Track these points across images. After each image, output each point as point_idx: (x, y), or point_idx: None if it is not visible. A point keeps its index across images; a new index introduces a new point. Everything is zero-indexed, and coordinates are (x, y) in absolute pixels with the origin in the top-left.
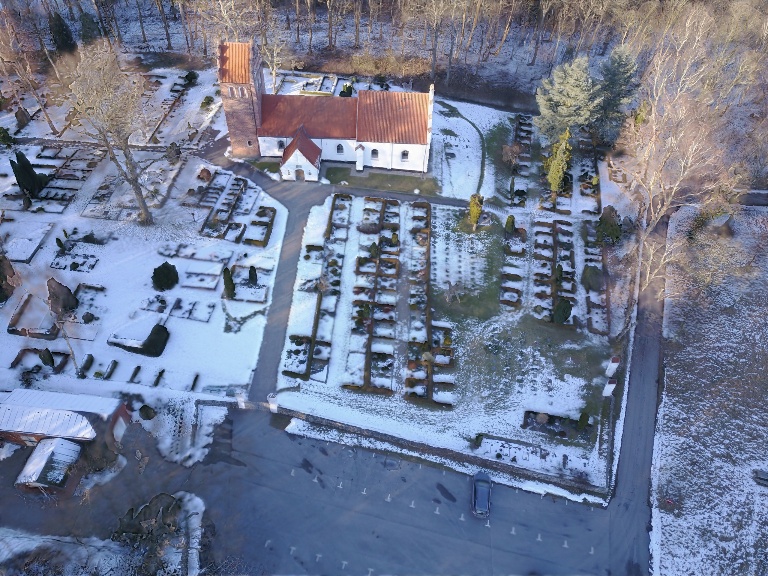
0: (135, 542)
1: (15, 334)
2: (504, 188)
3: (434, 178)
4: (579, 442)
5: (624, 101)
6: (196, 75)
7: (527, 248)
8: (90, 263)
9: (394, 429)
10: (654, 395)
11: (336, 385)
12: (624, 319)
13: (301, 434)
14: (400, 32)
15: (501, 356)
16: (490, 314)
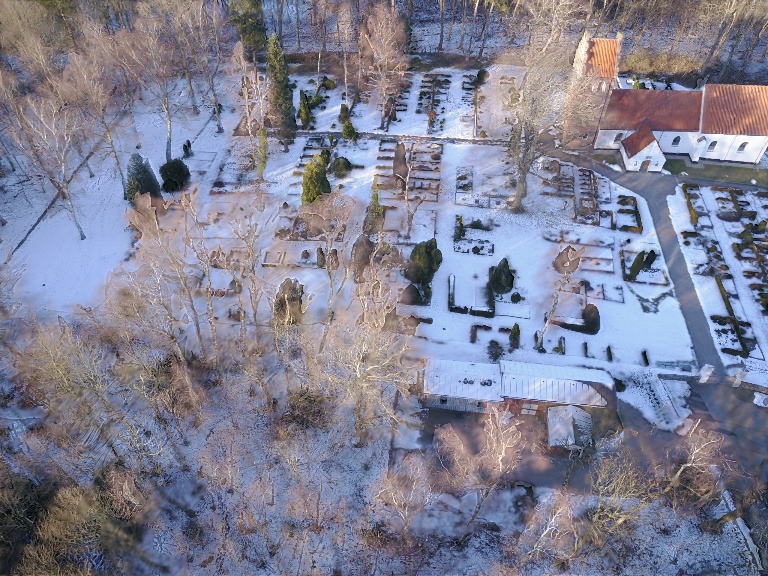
0: (759, 496)
1: (456, 312)
2: None
3: (766, 169)
4: None
5: None
6: (487, 73)
7: None
8: (488, 247)
9: None
10: None
11: None
12: None
13: None
14: None
15: None
16: None
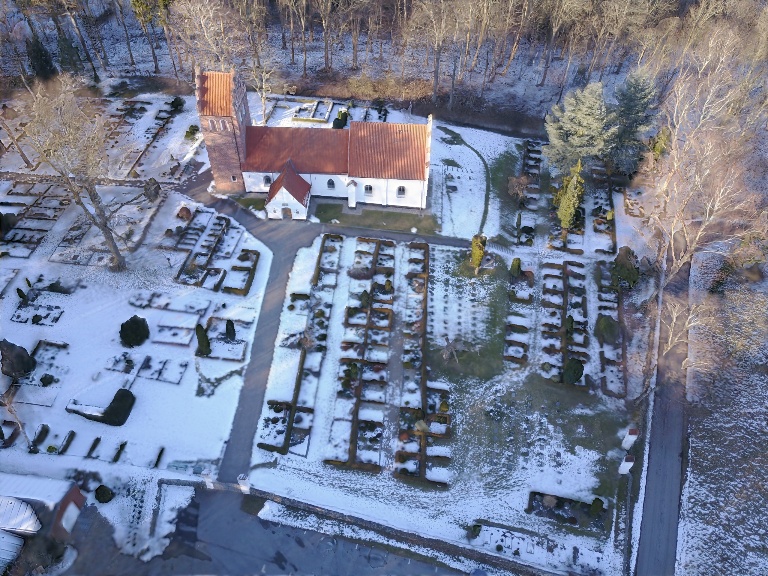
0: None
1: None
2: (510, 224)
3: (433, 215)
4: (592, 531)
5: (641, 129)
6: (182, 101)
7: (534, 294)
8: (54, 315)
9: (381, 514)
10: (677, 472)
11: (317, 459)
12: (642, 379)
13: (275, 520)
14: (401, 51)
15: (504, 424)
16: (492, 373)
